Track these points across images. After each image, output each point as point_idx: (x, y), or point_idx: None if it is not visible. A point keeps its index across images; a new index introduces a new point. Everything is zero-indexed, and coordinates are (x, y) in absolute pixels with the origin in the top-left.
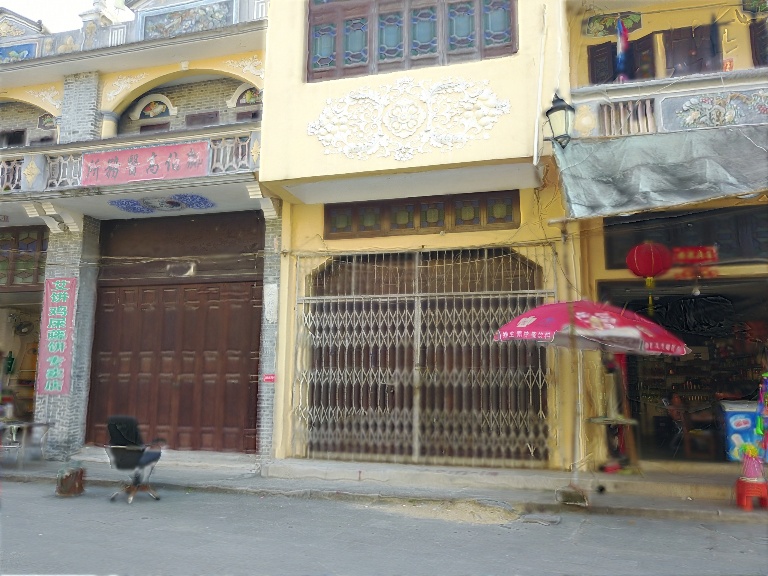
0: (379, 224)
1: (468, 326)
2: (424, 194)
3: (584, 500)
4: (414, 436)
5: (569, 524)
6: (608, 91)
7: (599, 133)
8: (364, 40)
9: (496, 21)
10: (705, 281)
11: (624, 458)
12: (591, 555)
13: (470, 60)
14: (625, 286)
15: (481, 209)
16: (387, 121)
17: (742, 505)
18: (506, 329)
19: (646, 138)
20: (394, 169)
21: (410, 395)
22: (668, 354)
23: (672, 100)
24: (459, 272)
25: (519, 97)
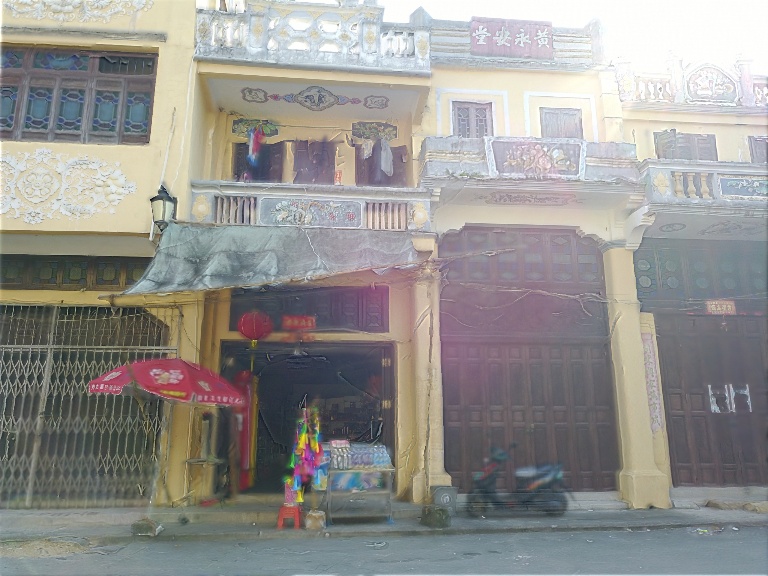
0: (21, 277)
1: (96, 377)
2: (69, 253)
3: (154, 531)
4: (30, 482)
5: (127, 552)
6: (221, 186)
7: (211, 219)
8: (11, 107)
9: (136, 113)
10: (306, 344)
11: (228, 493)
12: (107, 574)
13: (109, 142)
14: (244, 346)
15: (122, 271)
16: (21, 186)
17: (280, 526)
18: (95, 382)
19: (242, 229)
20: (22, 230)
21: (31, 442)
22: (224, 405)
23: (269, 200)
24: (94, 327)
25: (144, 181)
